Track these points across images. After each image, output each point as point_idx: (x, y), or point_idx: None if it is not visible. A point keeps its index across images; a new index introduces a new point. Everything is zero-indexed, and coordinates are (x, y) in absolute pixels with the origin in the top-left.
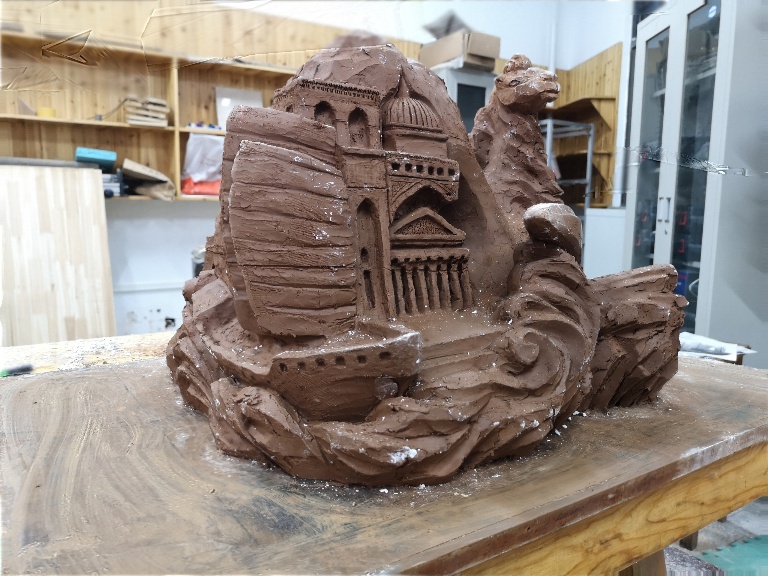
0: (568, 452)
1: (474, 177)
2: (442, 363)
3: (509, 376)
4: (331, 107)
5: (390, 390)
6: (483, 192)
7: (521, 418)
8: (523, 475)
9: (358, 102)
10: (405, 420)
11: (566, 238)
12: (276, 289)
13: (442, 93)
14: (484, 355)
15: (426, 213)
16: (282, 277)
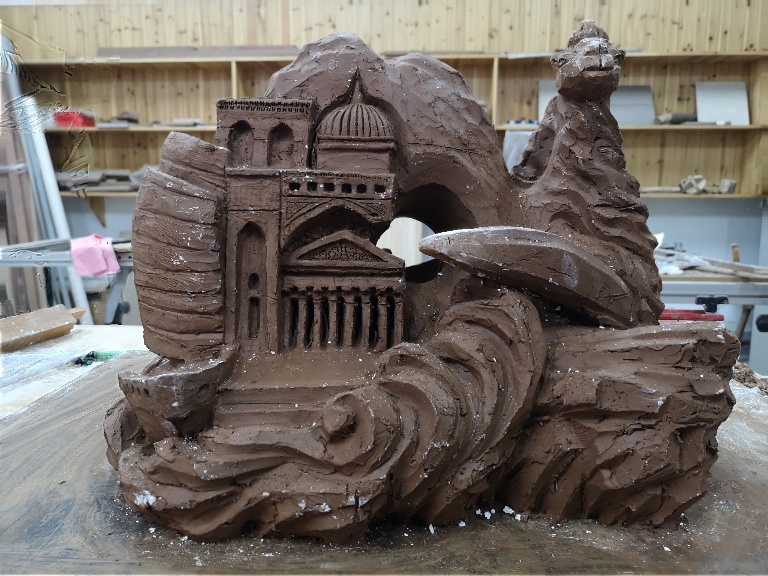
0: (396, 557)
1: (467, 190)
2: (247, 411)
3: (317, 442)
4: (250, 126)
5: (171, 428)
6: (482, 208)
7: (301, 496)
8: (292, 565)
9: (283, 117)
10: (153, 463)
11: (505, 275)
12: (151, 309)
13: (426, 91)
14: (306, 411)
15: (342, 237)
16: (153, 298)
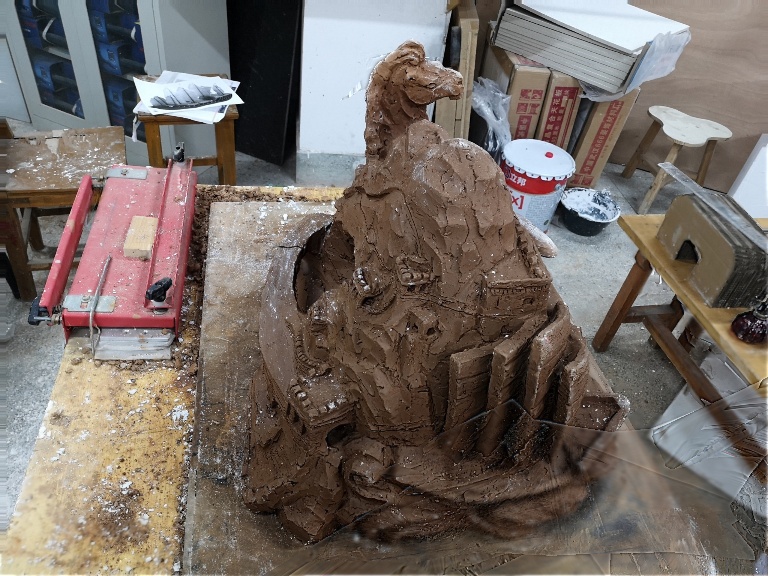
0: None
1: None
2: None
3: None
4: None
5: None
6: None
7: None
8: None
9: None
10: None
11: None
12: None
13: None
14: None
15: None
16: None
